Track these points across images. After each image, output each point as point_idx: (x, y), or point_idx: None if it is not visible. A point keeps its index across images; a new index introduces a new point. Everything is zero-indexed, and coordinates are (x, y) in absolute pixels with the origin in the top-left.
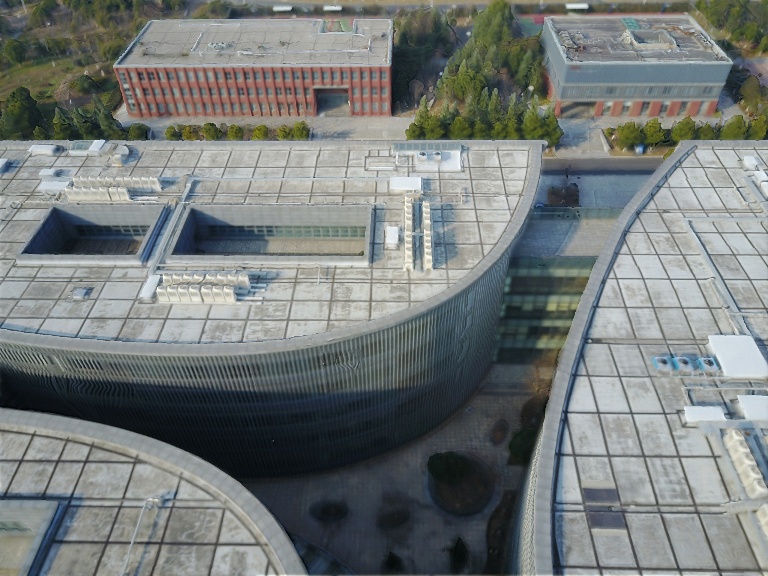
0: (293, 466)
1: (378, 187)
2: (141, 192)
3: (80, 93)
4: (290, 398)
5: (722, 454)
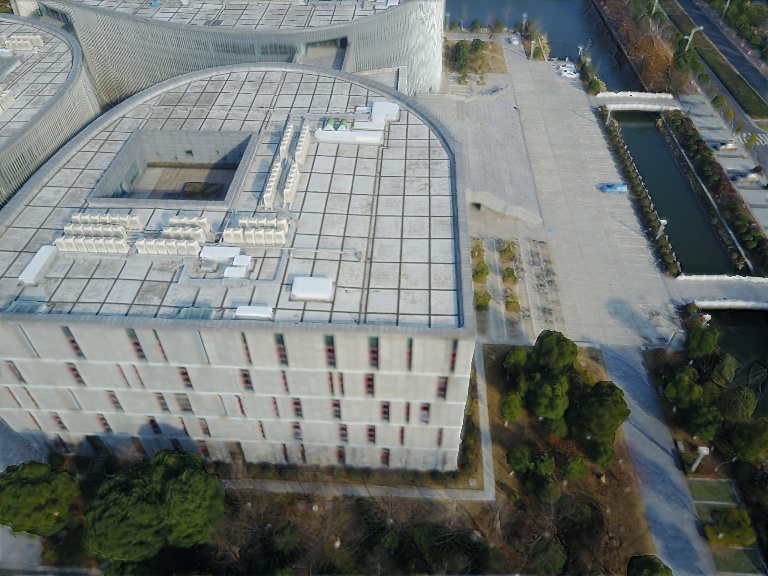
0: None
1: None
2: None
3: None
4: None
5: (204, 1)
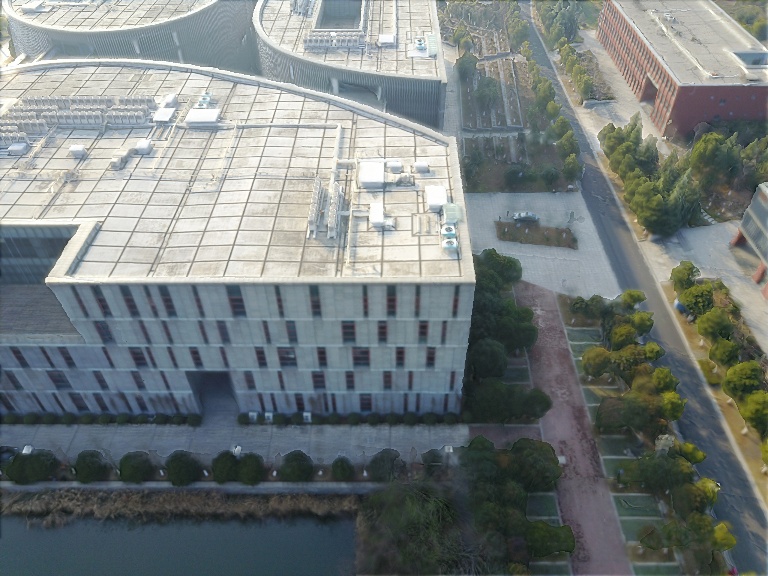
0: None
1: None
2: None
3: None
4: None
5: None
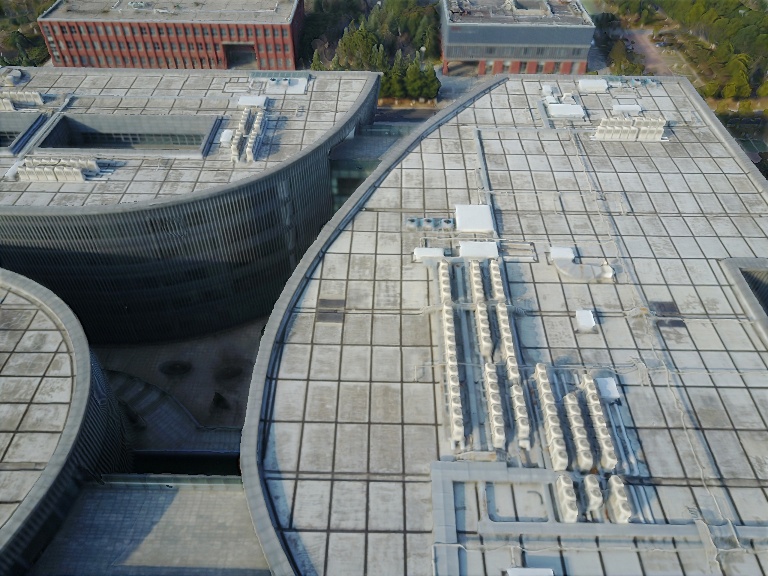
0: (149, 335)
1: (230, 104)
2: (25, 105)
3: (11, 47)
4: (130, 261)
5: (434, 278)
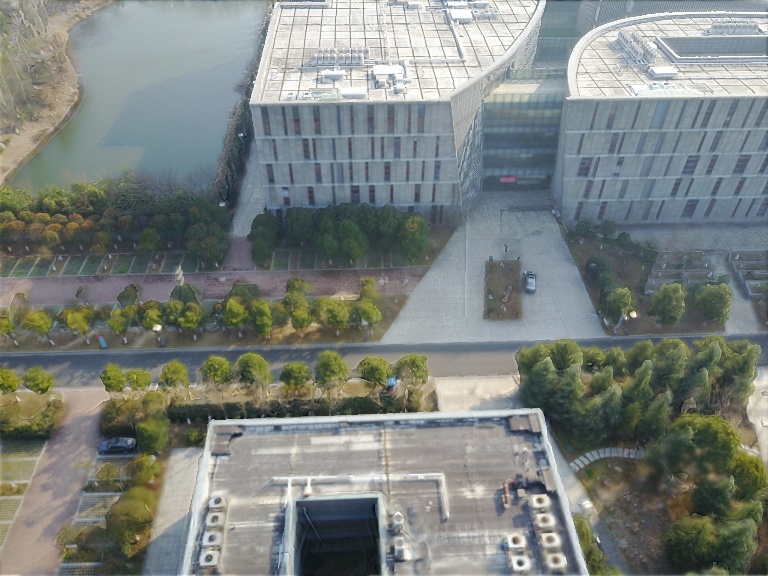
0: None
1: None
2: None
3: None
4: None
5: None
